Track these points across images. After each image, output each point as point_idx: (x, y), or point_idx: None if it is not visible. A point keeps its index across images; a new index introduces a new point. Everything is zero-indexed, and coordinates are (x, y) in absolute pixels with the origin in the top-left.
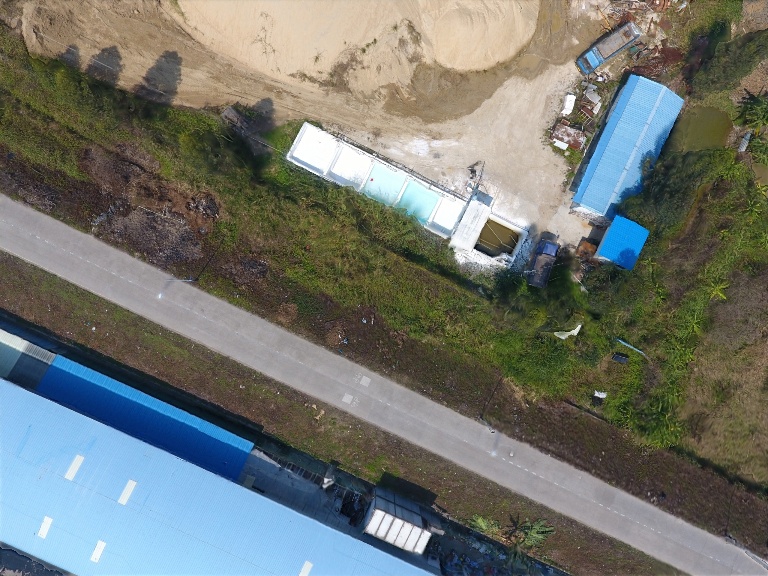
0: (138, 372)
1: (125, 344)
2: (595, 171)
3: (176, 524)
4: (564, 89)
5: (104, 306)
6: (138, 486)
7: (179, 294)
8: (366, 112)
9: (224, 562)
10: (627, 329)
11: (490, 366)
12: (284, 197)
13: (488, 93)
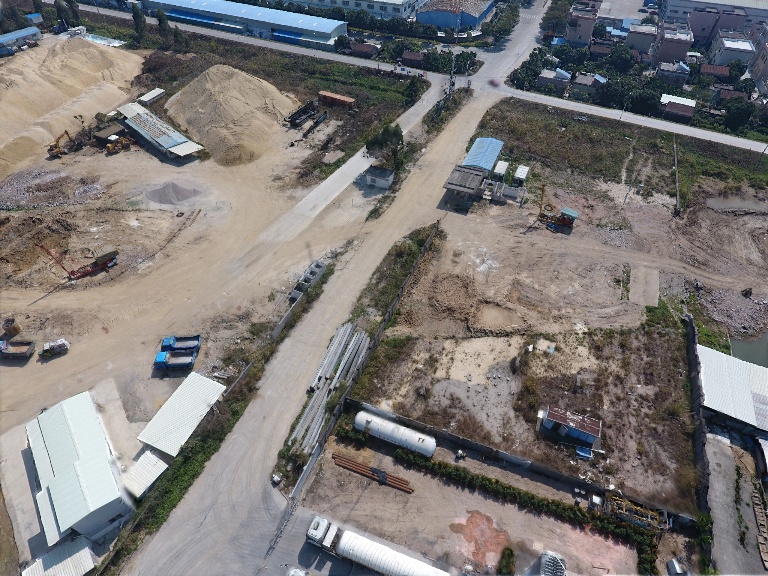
0: None
1: None
2: (29, 32)
3: None
4: None
5: None
6: (191, 2)
7: None
8: None
9: None
10: None
11: None
12: None
13: None
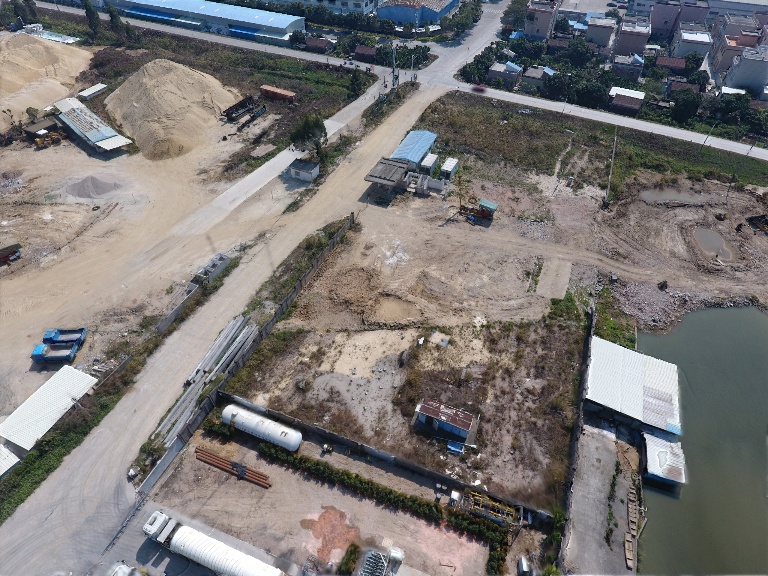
0: None
1: None
2: None
3: None
4: None
5: None
6: None
7: None
8: None
9: None
10: None
11: None
12: None
13: None
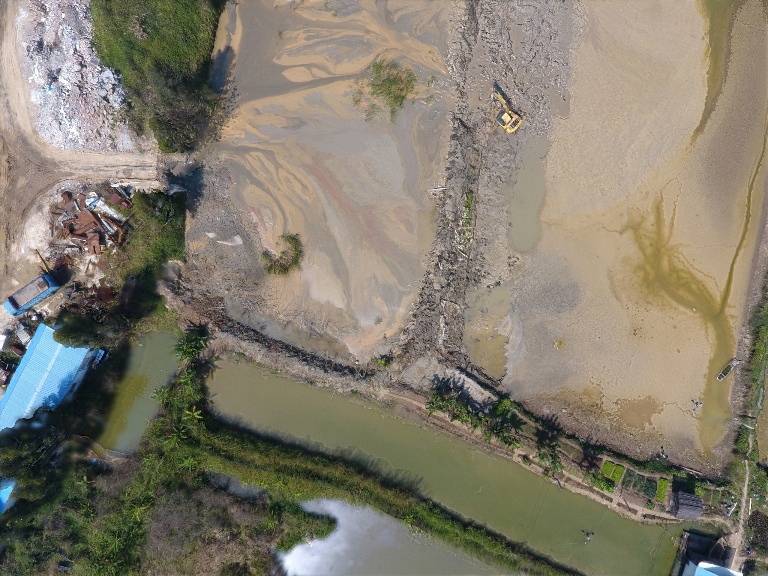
0: None
1: None
2: (2, 412)
3: None
4: (4, 326)
5: None
6: None
7: None
8: None
9: None
10: (62, 543)
11: None
12: None
13: None
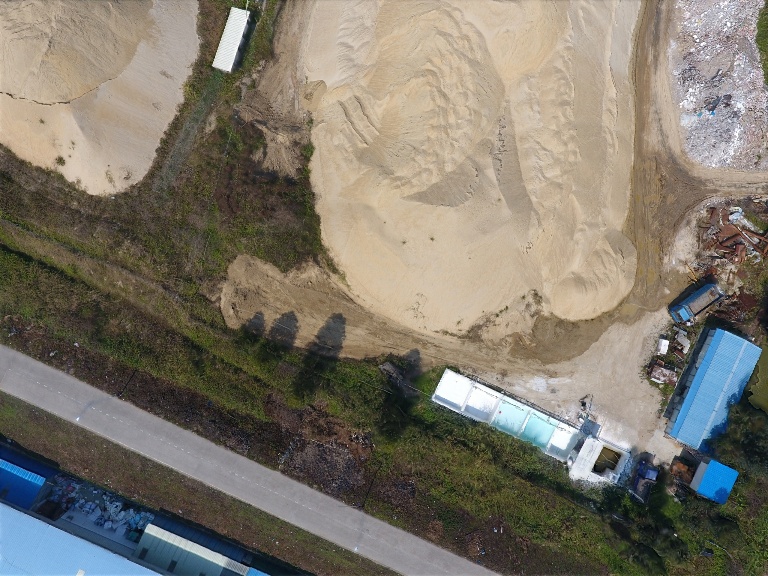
0: (310, 574)
1: (302, 554)
2: (689, 411)
3: None
4: (658, 332)
5: (289, 529)
6: None
7: (349, 518)
8: (495, 357)
9: None
10: None
11: (598, 564)
12: (433, 436)
13: (595, 337)
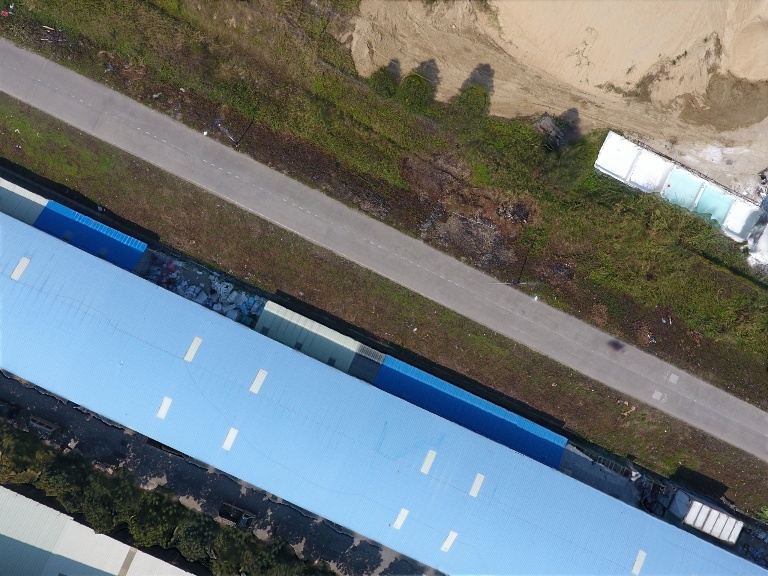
0: (449, 371)
1: (443, 344)
2: None
3: (522, 515)
4: None
5: (433, 308)
6: (486, 479)
7: (502, 296)
8: (664, 121)
9: (567, 551)
10: None
11: None
12: (598, 203)
13: None
